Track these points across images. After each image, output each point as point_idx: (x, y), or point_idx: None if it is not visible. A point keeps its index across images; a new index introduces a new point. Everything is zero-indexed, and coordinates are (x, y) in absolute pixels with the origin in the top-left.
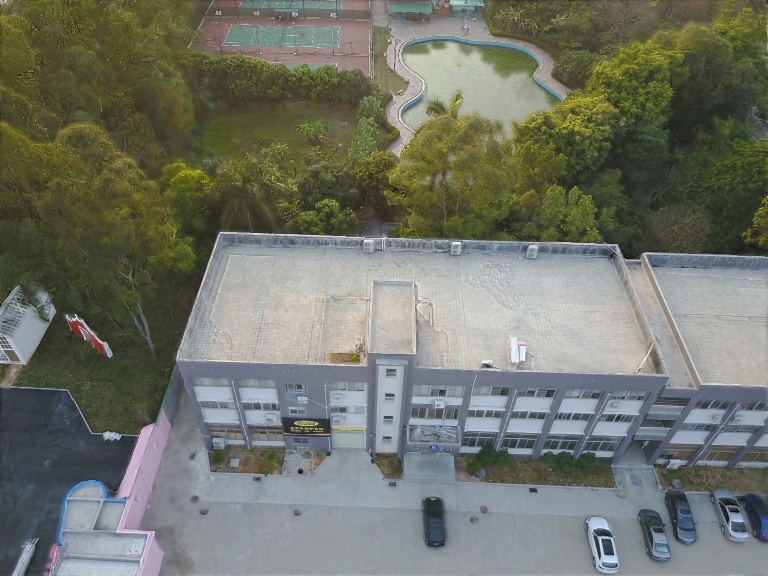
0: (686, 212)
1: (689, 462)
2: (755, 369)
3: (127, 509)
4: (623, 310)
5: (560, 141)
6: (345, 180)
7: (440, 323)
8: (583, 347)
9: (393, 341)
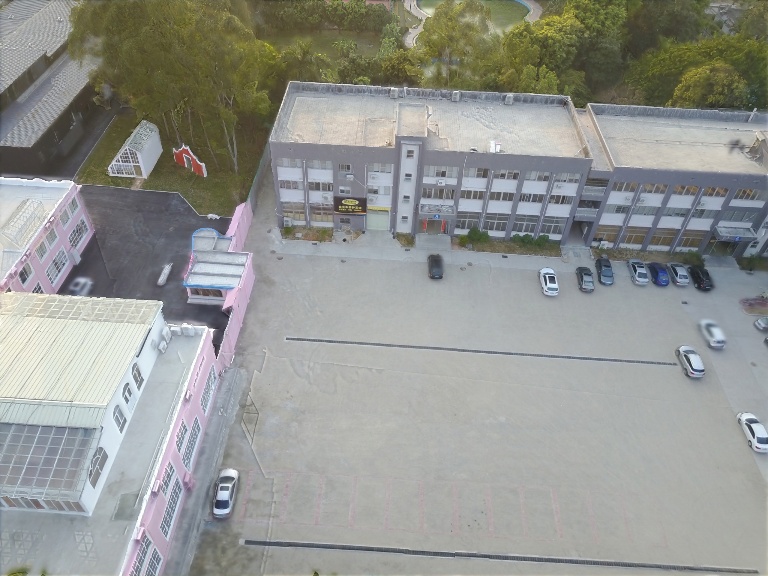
0: (630, 96)
1: (614, 244)
2: (655, 166)
3: (233, 242)
4: (569, 132)
5: (537, 44)
6: (374, 66)
7: (443, 134)
8: (539, 149)
9: (412, 132)
